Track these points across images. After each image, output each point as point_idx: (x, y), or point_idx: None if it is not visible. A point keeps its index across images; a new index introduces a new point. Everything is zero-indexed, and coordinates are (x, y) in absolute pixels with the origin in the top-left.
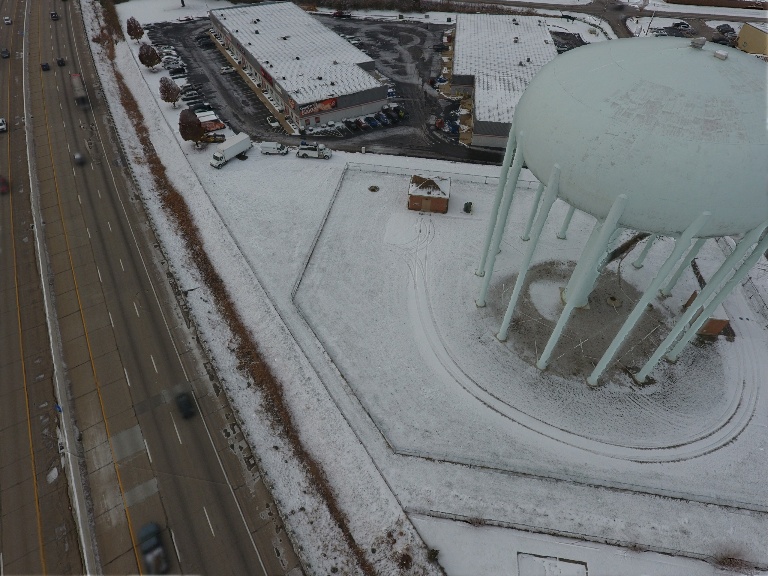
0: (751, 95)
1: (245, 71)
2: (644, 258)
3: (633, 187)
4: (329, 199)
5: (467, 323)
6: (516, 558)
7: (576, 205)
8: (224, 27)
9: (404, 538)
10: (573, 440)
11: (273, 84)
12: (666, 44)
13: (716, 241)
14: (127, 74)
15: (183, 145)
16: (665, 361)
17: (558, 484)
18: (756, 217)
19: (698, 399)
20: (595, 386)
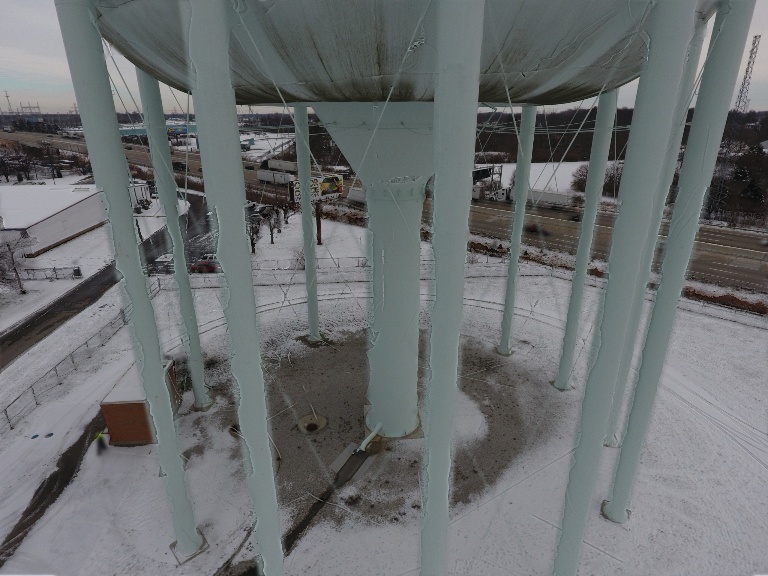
0: None
1: None
2: None
3: None
4: None
5: None
6: None
7: None
8: None
9: None
10: None
11: None
12: None
13: None
14: None
15: None
16: (268, 357)
17: None
18: None
19: None
20: None
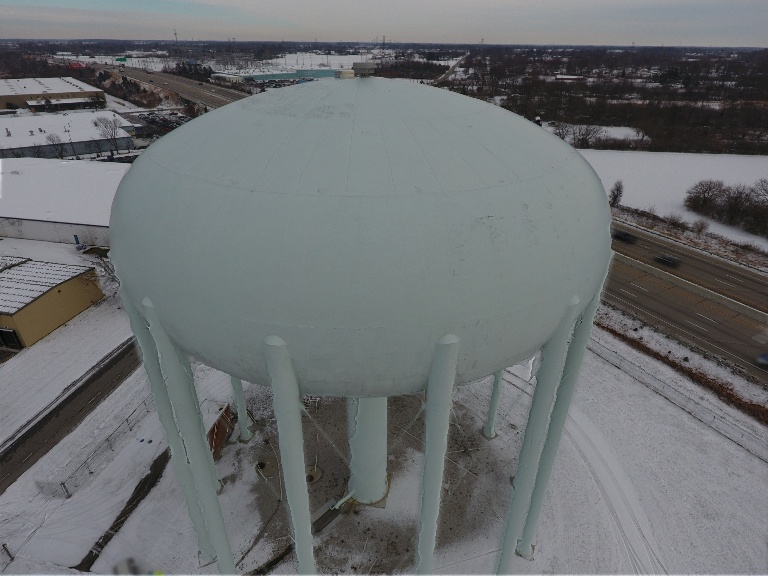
0: None
1: None
2: None
3: None
4: None
5: None
6: None
7: None
8: None
9: None
10: None
11: None
12: (397, 85)
13: None
14: None
15: None
16: None
17: None
18: None
19: None
20: None
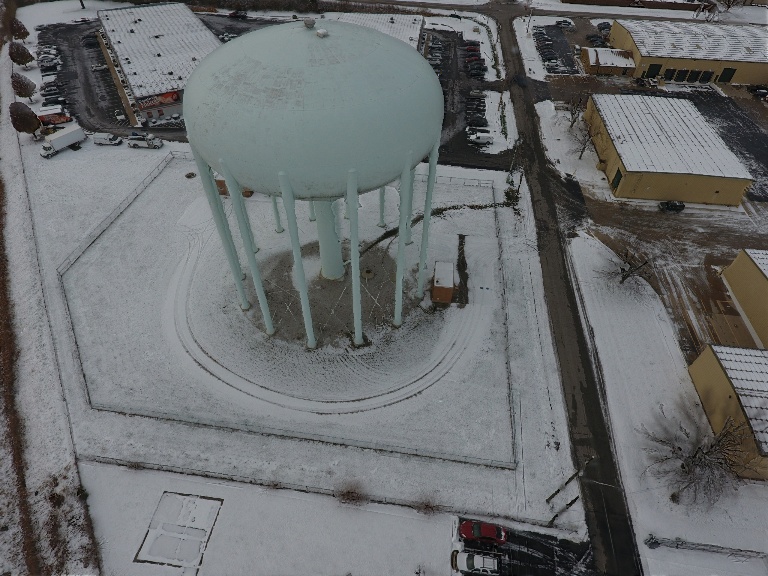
0: (323, 67)
1: (116, 68)
2: None
3: (223, 151)
4: (142, 185)
5: (219, 295)
6: (160, 496)
7: None
8: (102, 27)
9: (66, 481)
10: (267, 395)
11: (126, 79)
12: (293, 25)
13: (495, 220)
14: (2, 72)
15: (22, 137)
16: (390, 326)
17: (233, 433)
18: (331, 177)
19: (403, 359)
20: (312, 348)
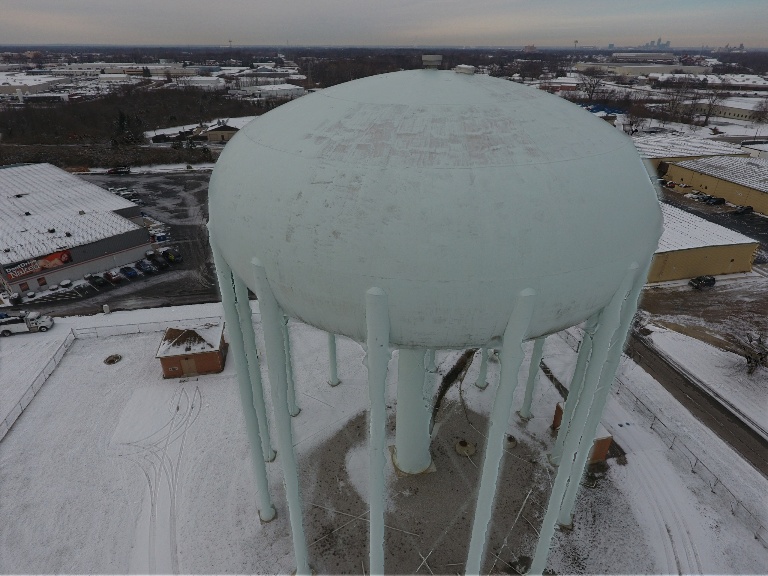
0: (523, 102)
1: None
2: (486, 373)
3: (385, 270)
4: (29, 392)
5: (242, 565)
6: None
7: (318, 326)
8: None
9: None
10: None
11: None
12: None
13: None
14: None
15: None
16: (558, 529)
17: None
18: (605, 284)
19: None
20: None
